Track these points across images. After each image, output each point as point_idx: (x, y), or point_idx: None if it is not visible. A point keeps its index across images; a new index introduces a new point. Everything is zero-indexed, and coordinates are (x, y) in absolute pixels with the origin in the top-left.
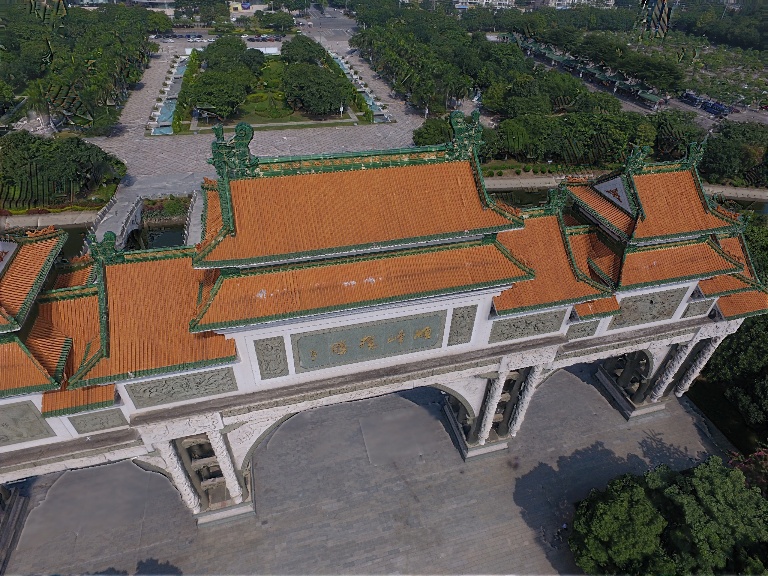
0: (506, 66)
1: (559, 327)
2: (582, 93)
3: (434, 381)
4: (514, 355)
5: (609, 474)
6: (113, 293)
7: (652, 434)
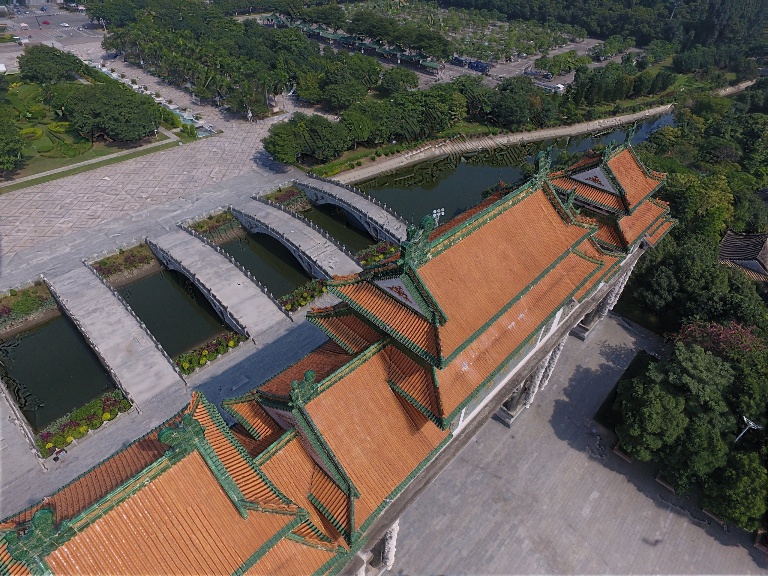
0: (297, 52)
1: None
2: (382, 71)
3: None
4: None
5: (598, 385)
6: (323, 432)
7: (602, 343)
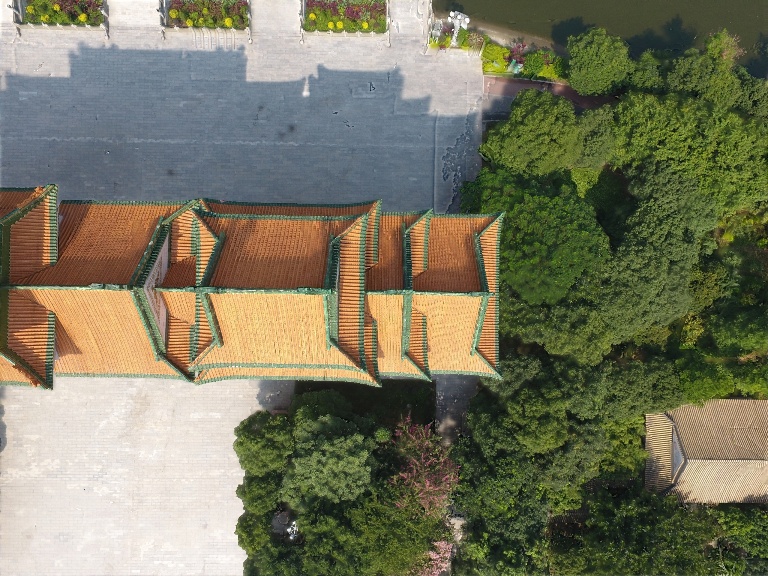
0: None
1: None
2: None
3: None
4: None
5: None
6: None
7: None
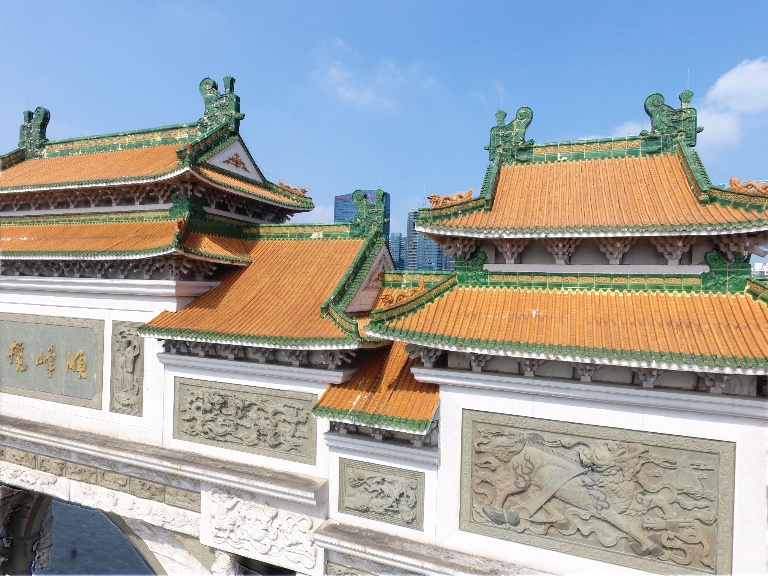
0: None
1: (315, 453)
2: None
3: (98, 501)
4: (220, 495)
5: None
6: None
7: None
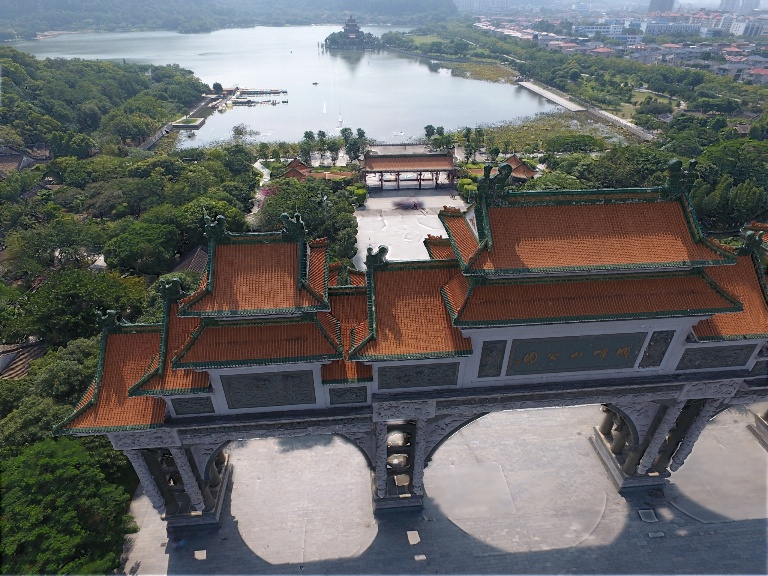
0: None
1: None
2: None
3: None
4: None
5: None
6: None
7: None
